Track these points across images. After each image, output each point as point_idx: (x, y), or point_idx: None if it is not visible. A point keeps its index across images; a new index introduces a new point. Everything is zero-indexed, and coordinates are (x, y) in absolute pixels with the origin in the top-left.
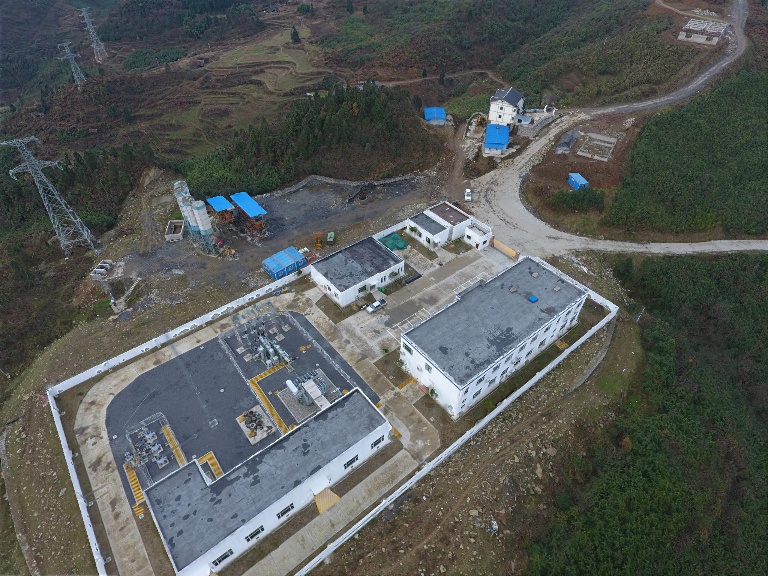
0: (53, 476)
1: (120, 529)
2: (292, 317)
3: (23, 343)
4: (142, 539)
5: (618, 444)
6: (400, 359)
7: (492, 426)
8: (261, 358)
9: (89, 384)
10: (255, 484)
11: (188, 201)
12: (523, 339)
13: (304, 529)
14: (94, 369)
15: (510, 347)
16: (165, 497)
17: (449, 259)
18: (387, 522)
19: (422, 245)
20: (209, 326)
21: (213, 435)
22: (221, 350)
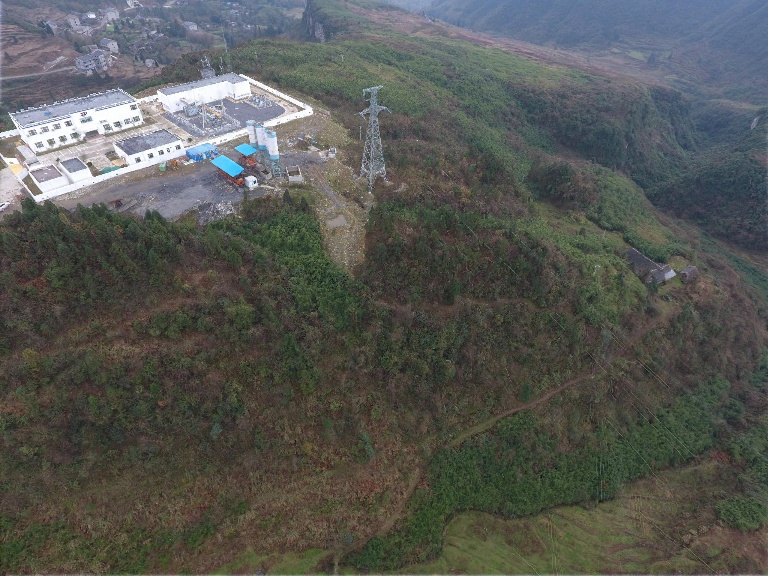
0: None
1: None
2: (198, 128)
3: None
4: None
5: None
6: None
7: None
8: None
9: None
10: (211, 82)
11: None
12: None
13: None
14: (297, 113)
15: (83, 100)
16: None
17: None
18: None
19: None
20: None
21: (236, 106)
22: None
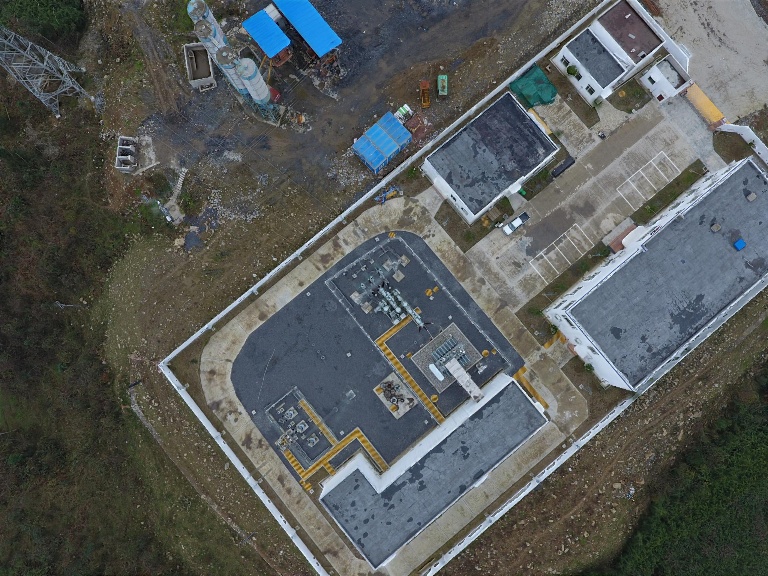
0: (209, 448)
1: (297, 503)
2: (412, 250)
3: (78, 263)
4: (320, 511)
5: (761, 391)
6: (555, 326)
7: (644, 395)
8: (383, 310)
9: (197, 348)
10: (422, 489)
11: (228, 61)
12: (715, 316)
13: (462, 500)
14: (197, 334)
15: (697, 326)
16: (341, 503)
17: (615, 124)
18: (536, 492)
19: (577, 94)
20: (307, 259)
21: (354, 408)
22: (332, 297)
